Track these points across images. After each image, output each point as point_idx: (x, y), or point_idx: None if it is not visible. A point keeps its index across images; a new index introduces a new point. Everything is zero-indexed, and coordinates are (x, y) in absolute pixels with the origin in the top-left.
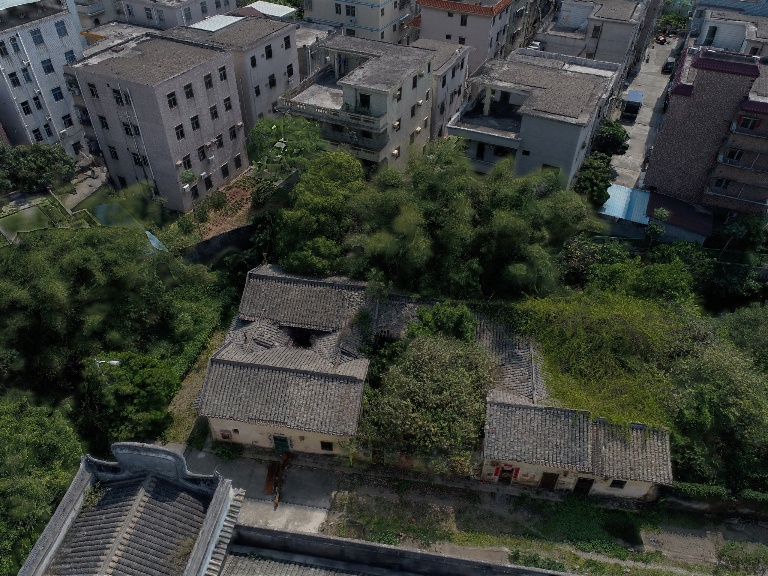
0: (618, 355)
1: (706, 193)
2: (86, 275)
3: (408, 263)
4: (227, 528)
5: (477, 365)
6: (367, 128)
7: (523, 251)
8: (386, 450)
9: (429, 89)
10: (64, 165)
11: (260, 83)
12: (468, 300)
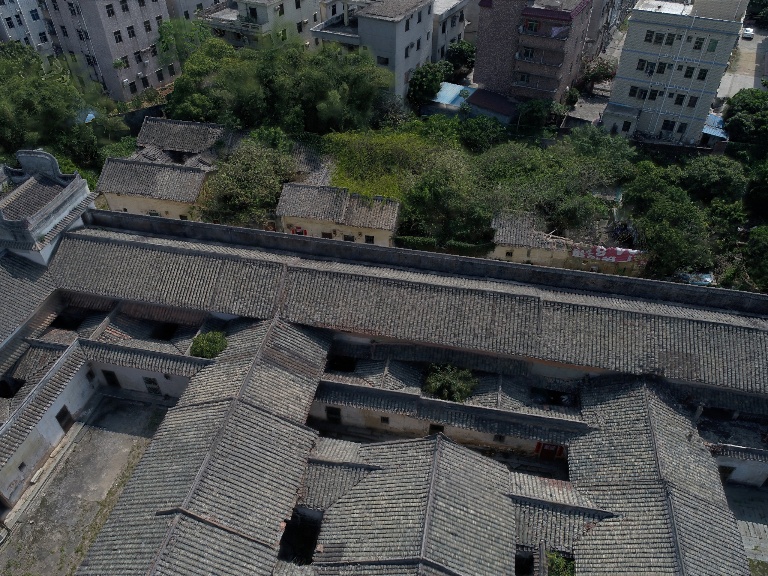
0: (386, 165)
1: (512, 85)
2: (28, 103)
3: (254, 109)
4: (82, 205)
5: (281, 162)
6: (254, 33)
7: (330, 98)
8: (221, 220)
9: (316, 13)
10: (32, 58)
11: (189, 9)
12: (293, 133)
